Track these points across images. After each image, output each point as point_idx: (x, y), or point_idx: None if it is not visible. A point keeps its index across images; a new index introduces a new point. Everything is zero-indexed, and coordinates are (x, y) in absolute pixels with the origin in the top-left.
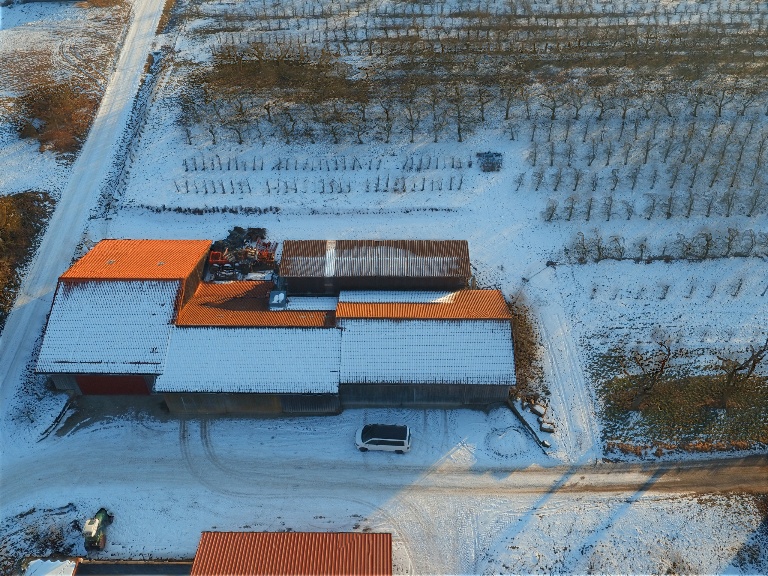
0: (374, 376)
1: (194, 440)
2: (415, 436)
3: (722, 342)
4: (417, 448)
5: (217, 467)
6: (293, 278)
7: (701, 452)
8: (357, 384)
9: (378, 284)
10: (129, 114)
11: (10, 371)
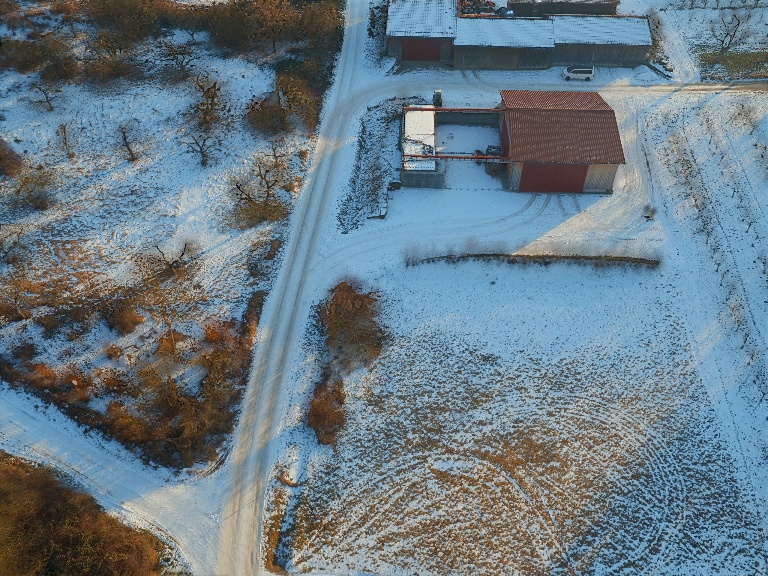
0: (573, 40)
1: (471, 77)
2: (594, 76)
3: (766, 39)
4: (597, 79)
5: (488, 85)
6: (516, 5)
7: (755, 79)
8: (564, 44)
9: (564, 11)
10: None
11: (357, 50)
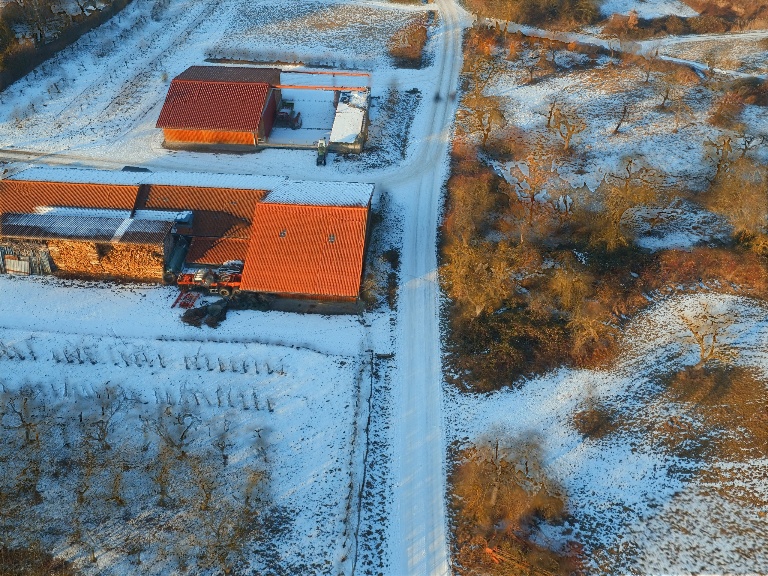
0: None
1: None
2: None
3: None
4: None
5: None
6: None
7: None
8: None
9: None
10: (387, 569)
11: (415, 231)
